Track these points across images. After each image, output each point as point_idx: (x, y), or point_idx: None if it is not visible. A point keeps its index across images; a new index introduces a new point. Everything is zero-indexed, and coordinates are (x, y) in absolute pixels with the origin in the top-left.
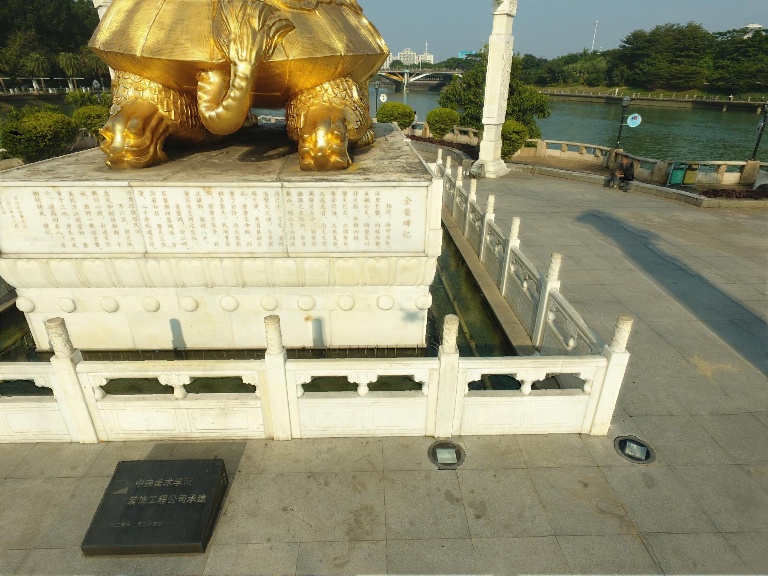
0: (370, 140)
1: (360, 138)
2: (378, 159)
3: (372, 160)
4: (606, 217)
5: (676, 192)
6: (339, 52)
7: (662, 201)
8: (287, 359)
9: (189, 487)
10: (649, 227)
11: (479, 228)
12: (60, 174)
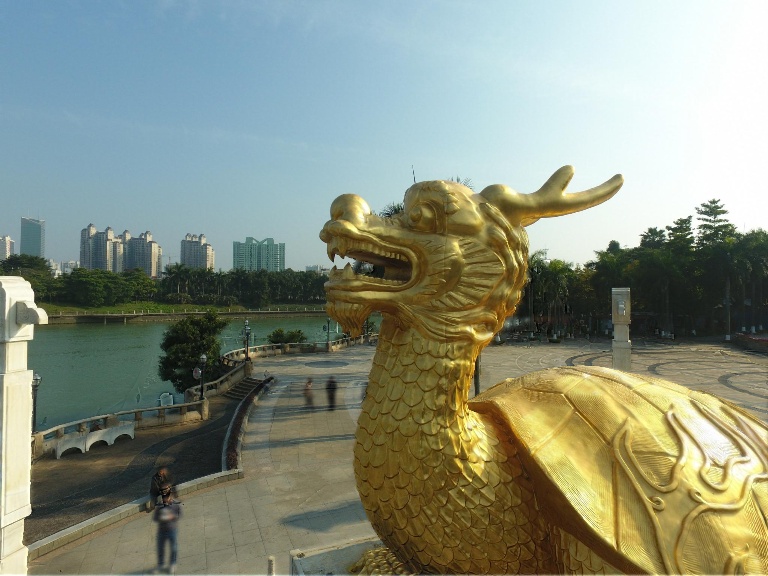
0: None
1: None
2: None
3: None
4: (299, 516)
5: (217, 477)
6: None
7: (224, 489)
8: None
9: None
10: (324, 501)
11: None
12: None
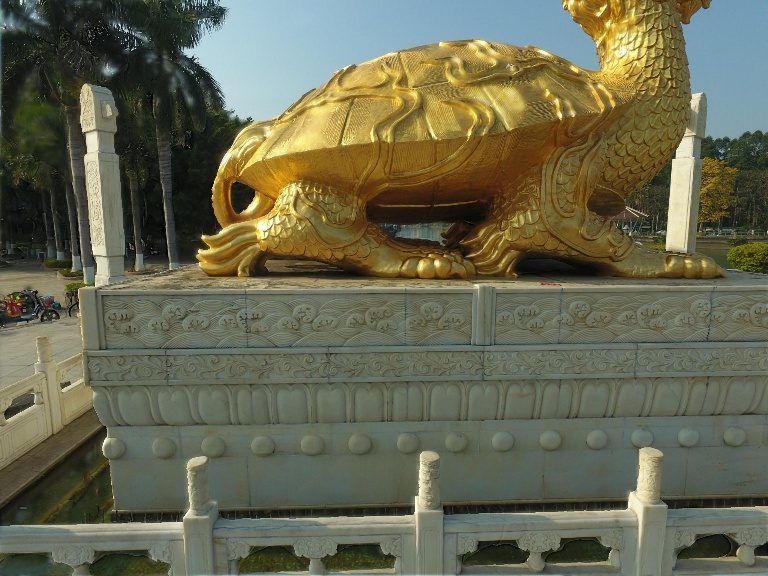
0: (421, 272)
1: (311, 256)
2: (273, 281)
3: (266, 280)
4: None
5: None
6: (263, 157)
7: None
8: (42, 372)
9: (25, 400)
10: None
11: (515, 567)
12: None
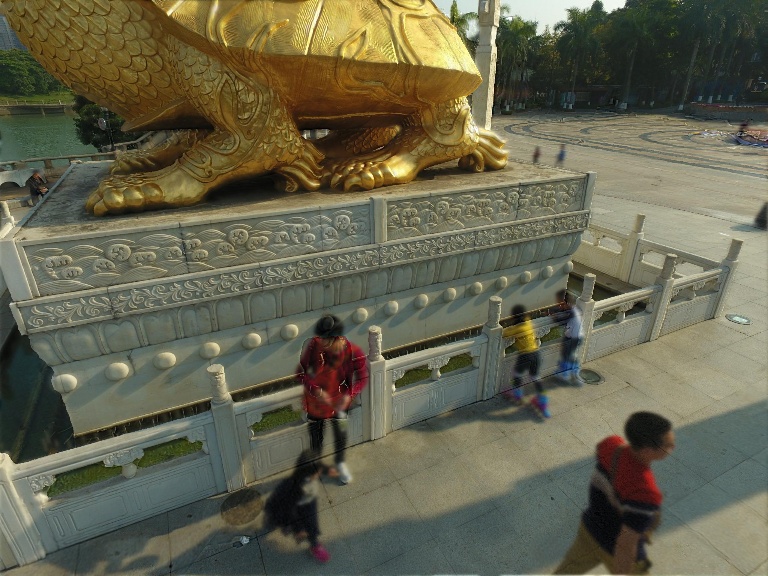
0: None
1: None
2: None
3: None
4: None
5: None
6: None
7: None
8: None
9: None
10: None
11: None
12: (537, 170)
